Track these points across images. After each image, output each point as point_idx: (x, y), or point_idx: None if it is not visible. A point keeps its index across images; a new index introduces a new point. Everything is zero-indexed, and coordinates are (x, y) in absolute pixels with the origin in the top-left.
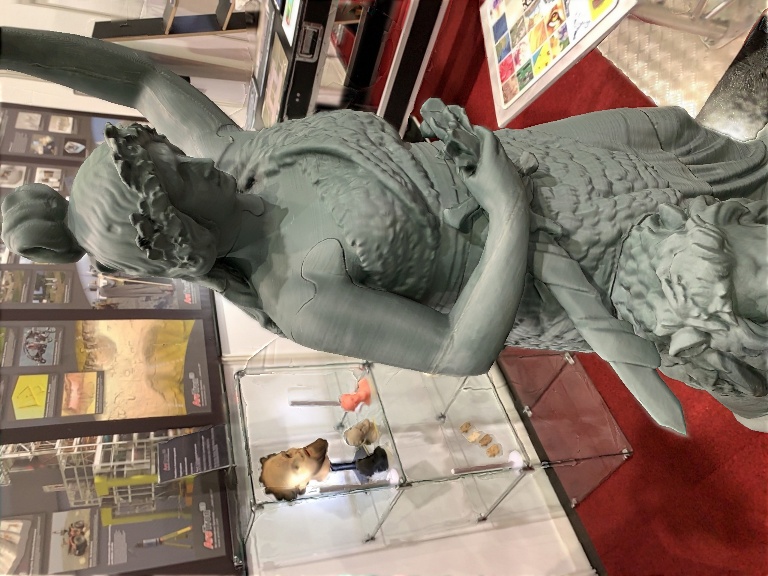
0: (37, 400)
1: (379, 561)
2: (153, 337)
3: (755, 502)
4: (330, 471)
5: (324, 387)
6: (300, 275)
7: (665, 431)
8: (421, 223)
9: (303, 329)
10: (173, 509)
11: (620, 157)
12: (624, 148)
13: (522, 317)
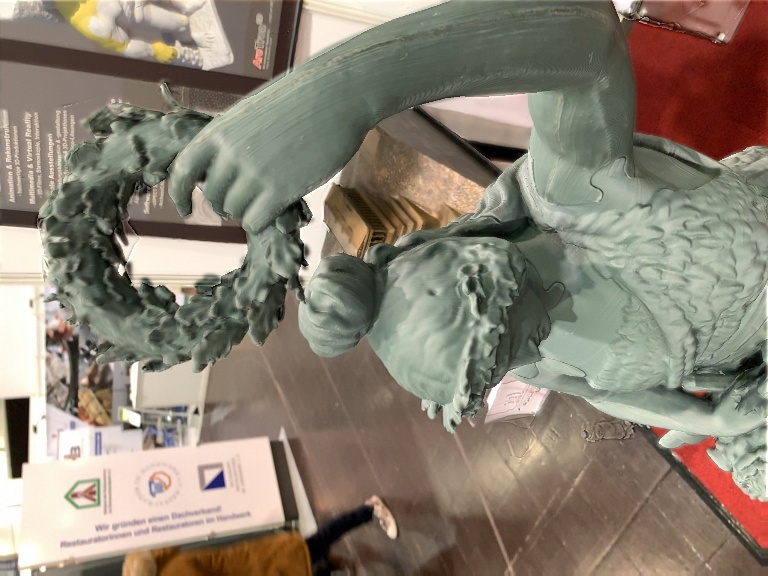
0: None
1: None
2: None
3: None
4: None
5: None
6: None
7: (766, 64)
8: None
9: None
10: None
11: None
12: None
13: None
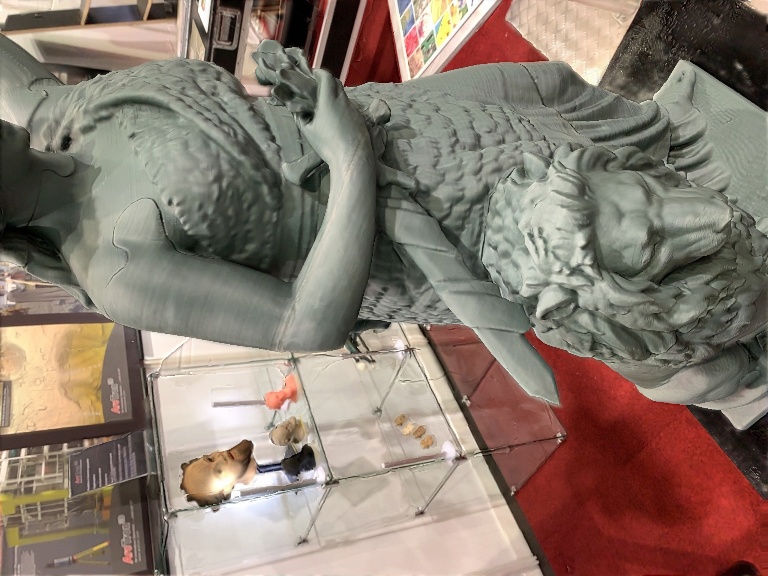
0: None
1: (314, 564)
2: (68, 342)
3: (682, 478)
4: (257, 473)
5: (255, 387)
6: (111, 242)
7: (596, 412)
8: (254, 179)
9: (116, 305)
10: (88, 524)
11: (492, 110)
12: (500, 102)
13: (385, 285)
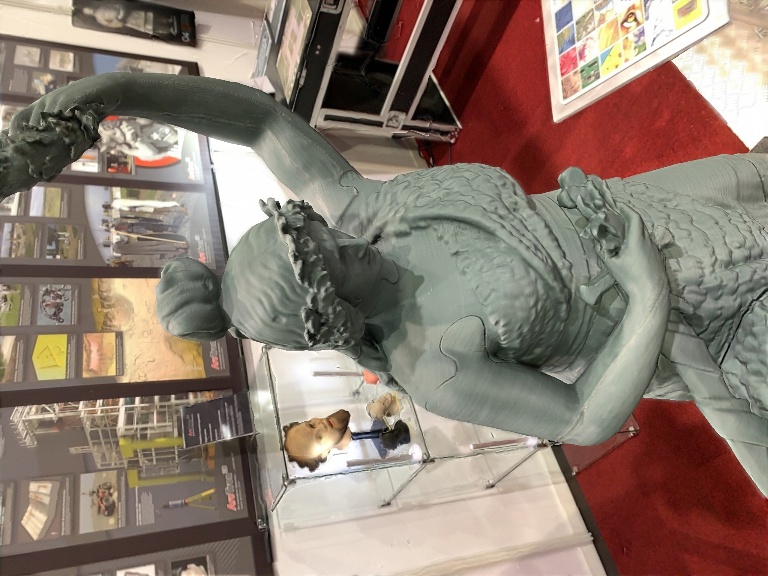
0: (58, 361)
1: (392, 523)
2: None
3: (757, 488)
4: (351, 440)
5: None
6: (439, 350)
7: (674, 414)
8: (559, 300)
9: (440, 403)
10: (196, 472)
11: (736, 219)
12: (734, 204)
13: None
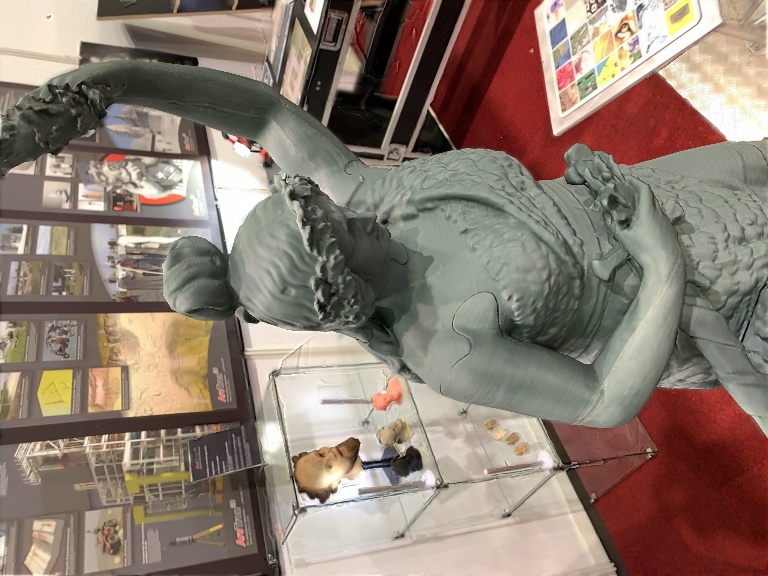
0: (63, 396)
1: (407, 557)
2: (175, 331)
3: None
4: (361, 470)
5: (347, 382)
6: (452, 328)
7: (692, 432)
8: (572, 275)
9: (455, 384)
10: (204, 507)
11: (745, 199)
12: (742, 187)
13: None
